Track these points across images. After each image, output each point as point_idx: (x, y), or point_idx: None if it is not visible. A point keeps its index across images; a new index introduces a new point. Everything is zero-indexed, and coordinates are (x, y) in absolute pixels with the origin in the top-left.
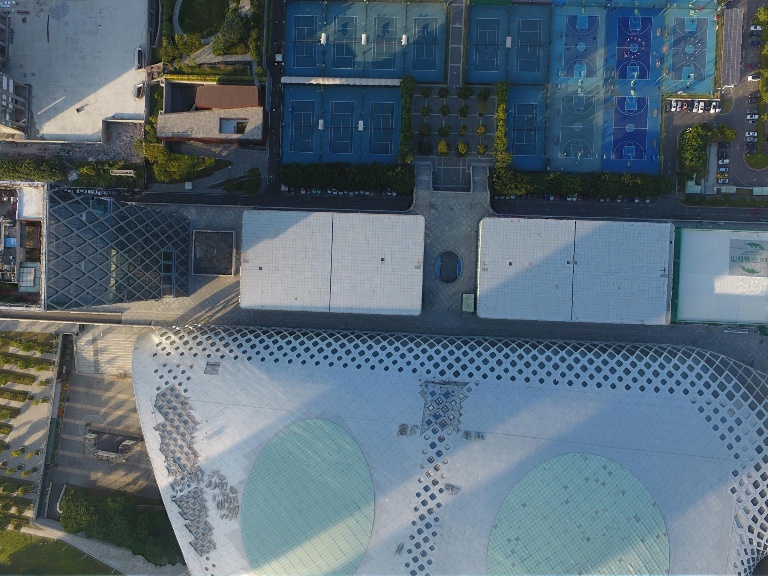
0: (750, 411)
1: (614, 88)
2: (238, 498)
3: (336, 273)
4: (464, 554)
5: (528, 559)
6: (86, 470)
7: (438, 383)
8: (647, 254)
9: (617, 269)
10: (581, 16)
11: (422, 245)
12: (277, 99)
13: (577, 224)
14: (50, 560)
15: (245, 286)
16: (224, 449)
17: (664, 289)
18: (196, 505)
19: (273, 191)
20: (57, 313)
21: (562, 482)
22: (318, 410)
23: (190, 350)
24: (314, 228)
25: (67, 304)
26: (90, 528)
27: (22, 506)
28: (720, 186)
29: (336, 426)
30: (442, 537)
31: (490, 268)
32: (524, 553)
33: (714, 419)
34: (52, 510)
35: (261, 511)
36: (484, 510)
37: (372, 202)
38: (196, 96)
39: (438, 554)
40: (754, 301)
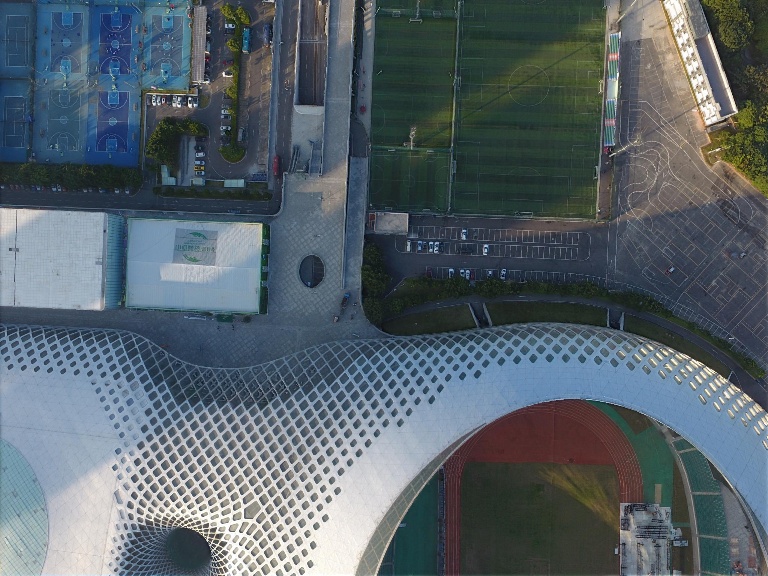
0: (144, 392)
1: (98, 83)
2: None
3: None
4: None
5: None
6: None
7: None
8: (83, 242)
9: (55, 256)
10: (65, 13)
11: None
12: None
13: (18, 213)
14: None
15: None
16: None
17: (99, 276)
18: None
19: None
20: None
21: None
22: None
23: None
24: None
25: None
26: None
27: None
28: None
29: None
30: None
31: None
32: None
33: (108, 400)
34: None
35: None
36: None
37: None
38: None
39: None
40: (197, 288)
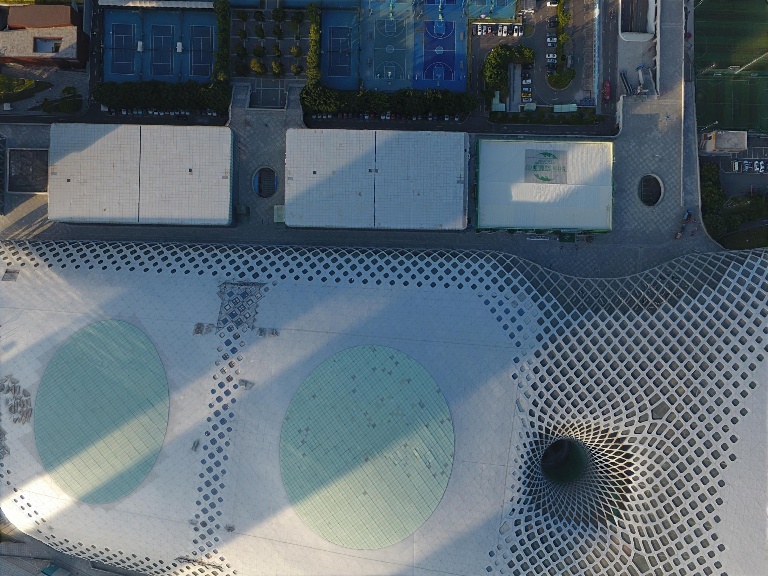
0: (532, 303)
1: (423, 13)
2: (31, 401)
3: (144, 184)
4: (258, 448)
5: (317, 448)
6: None
7: (236, 284)
8: (444, 161)
9: (416, 176)
10: None
11: (229, 156)
12: (98, 23)
13: (377, 134)
14: None
15: (53, 198)
16: (18, 353)
17: (460, 195)
18: None
19: (94, 112)
20: None
21: (350, 372)
22: (114, 312)
23: None
24: (122, 140)
25: None
26: None
27: None
28: (523, 104)
29: (131, 326)
30: (237, 432)
31: (295, 177)
32: (314, 443)
33: (498, 311)
34: None
35: (54, 413)
36: (277, 403)
37: (193, 122)
38: (8, 15)
39: (233, 449)
40: (549, 207)
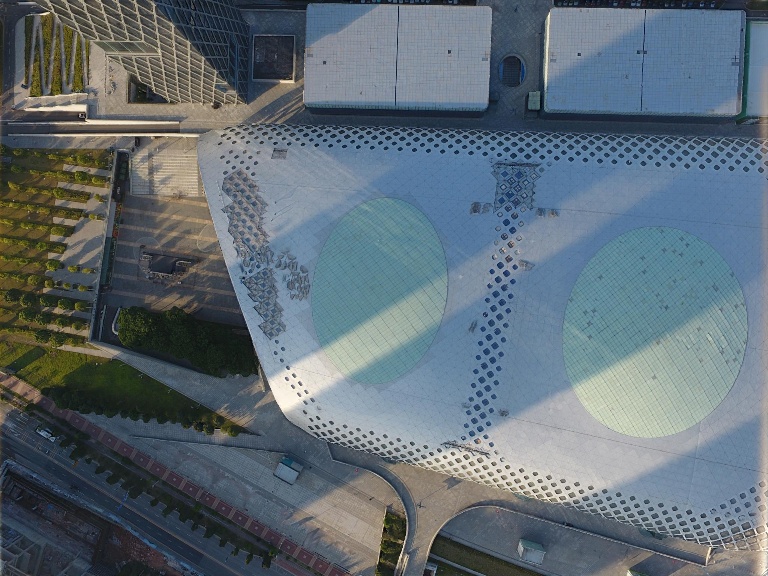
0: None
1: None
2: (309, 277)
3: (402, 66)
4: (539, 330)
5: (605, 330)
6: (140, 293)
7: (510, 165)
8: (718, 42)
9: (687, 58)
10: None
11: (489, 37)
12: None
13: (647, 13)
14: (105, 381)
15: (309, 81)
16: (294, 229)
17: (735, 77)
18: (265, 286)
19: (332, 1)
20: (113, 126)
21: (639, 253)
22: (389, 190)
23: (256, 139)
24: (379, 21)
25: (158, 3)
26: (148, 340)
27: (78, 322)
28: None
29: (408, 204)
30: (516, 314)
31: (558, 59)
32: (601, 324)
33: None
34: (106, 334)
35: (332, 289)
36: (559, 284)
37: None
38: None
39: (512, 331)
40: None
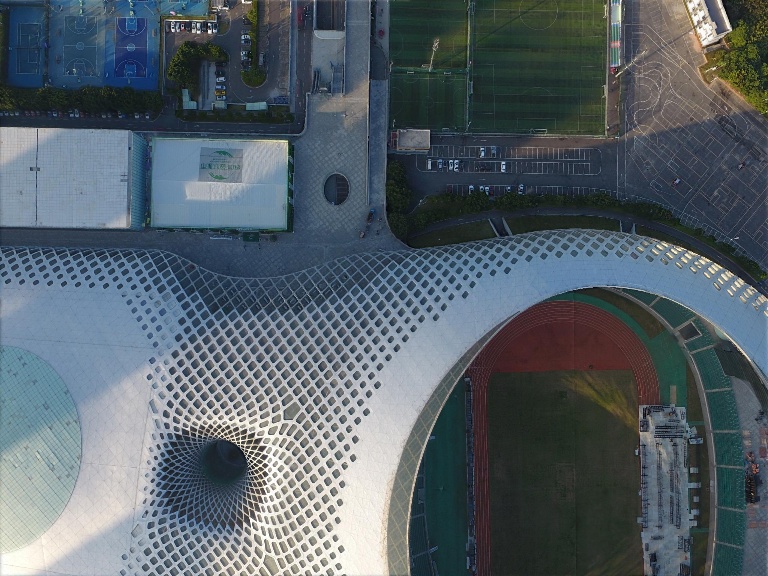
0: (177, 302)
1: (115, 9)
2: None
3: None
4: None
5: None
6: None
7: None
8: (107, 160)
9: (79, 175)
10: None
11: None
12: None
13: (39, 131)
14: None
15: None
16: None
17: (124, 193)
18: None
19: None
20: None
21: None
22: None
23: None
24: None
25: None
26: None
27: None
28: None
29: None
30: None
31: None
32: None
33: (139, 311)
34: None
35: None
36: None
37: None
38: None
39: None
40: (224, 206)
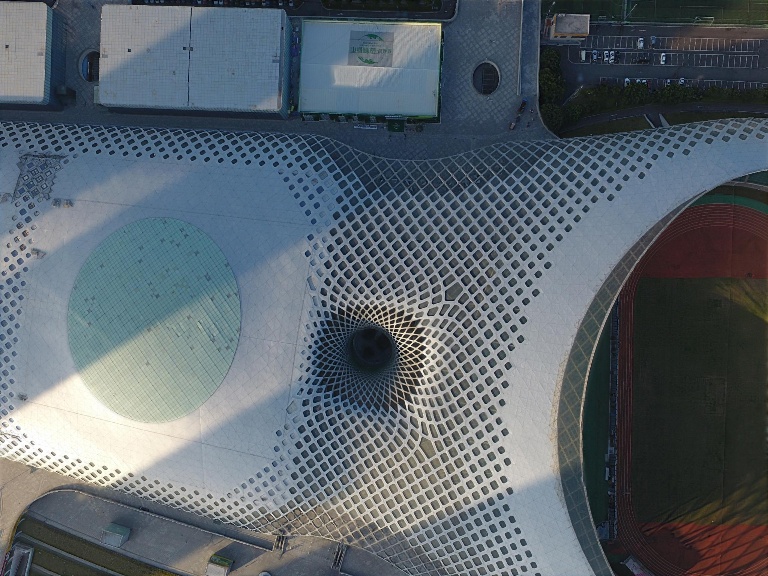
0: (333, 181)
1: None
2: None
3: None
4: (48, 317)
5: (102, 317)
6: None
7: (38, 156)
8: (260, 40)
9: (231, 55)
10: None
11: (44, 32)
12: None
13: (193, 10)
14: None
15: None
16: None
17: (276, 74)
18: None
19: None
20: None
21: (138, 243)
22: None
23: None
24: None
25: None
26: None
27: None
28: None
29: None
30: (28, 301)
31: (110, 55)
32: (99, 312)
33: (297, 188)
34: None
35: None
36: (66, 273)
37: None
38: None
39: (25, 318)
40: (373, 92)
